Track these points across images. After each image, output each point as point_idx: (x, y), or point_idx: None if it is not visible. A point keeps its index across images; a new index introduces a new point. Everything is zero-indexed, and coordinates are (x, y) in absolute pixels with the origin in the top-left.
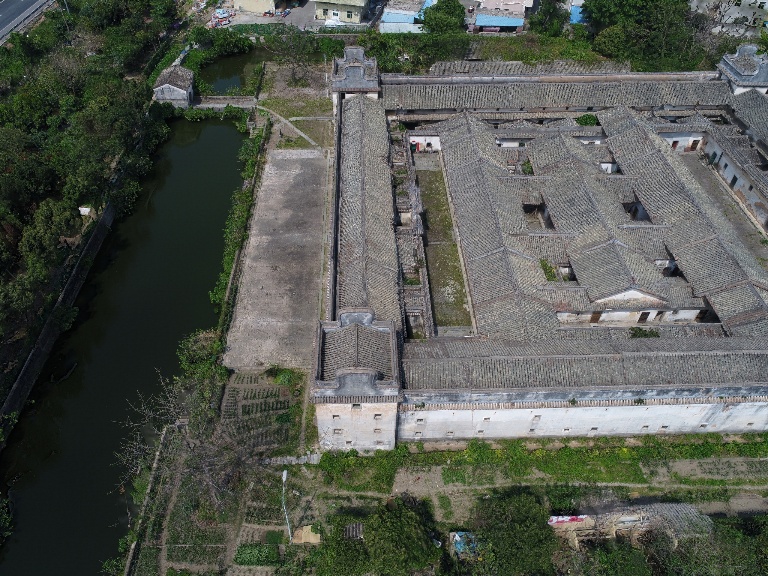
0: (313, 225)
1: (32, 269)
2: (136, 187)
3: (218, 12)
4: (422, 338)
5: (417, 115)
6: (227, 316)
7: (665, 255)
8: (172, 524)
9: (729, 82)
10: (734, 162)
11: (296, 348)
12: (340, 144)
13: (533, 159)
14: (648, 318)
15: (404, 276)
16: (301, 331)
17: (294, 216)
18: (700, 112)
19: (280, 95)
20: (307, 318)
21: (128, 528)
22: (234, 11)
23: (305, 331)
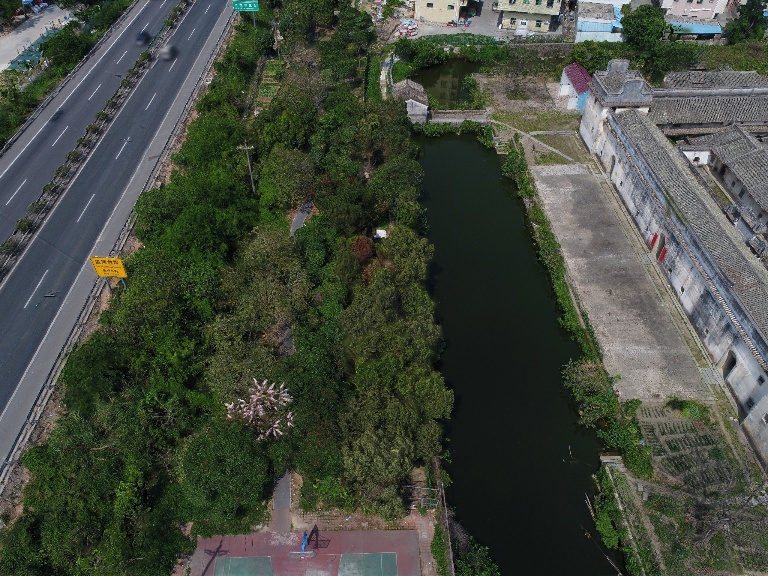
0: (621, 246)
1: (421, 300)
2: (420, 207)
3: (405, 23)
4: None
5: (683, 129)
6: (594, 344)
7: None
8: (671, 572)
9: None
10: None
11: (683, 378)
12: None
13: None
14: None
15: None
16: (677, 360)
17: (596, 236)
18: None
19: (506, 108)
20: (675, 345)
21: (611, 575)
22: (416, 21)
23: (681, 360)
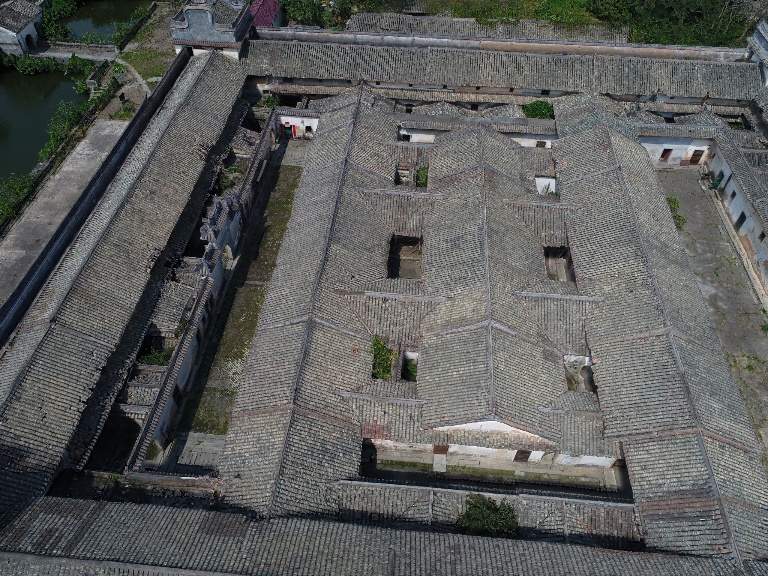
0: None
1: None
2: None
3: None
4: (154, 452)
5: (297, 86)
6: None
7: (582, 348)
8: None
9: (761, 66)
10: (744, 191)
11: None
12: (147, 122)
13: (433, 164)
14: (530, 457)
15: (163, 341)
16: None
17: None
18: (711, 108)
19: (154, 46)
20: None
21: None
22: None
23: None
